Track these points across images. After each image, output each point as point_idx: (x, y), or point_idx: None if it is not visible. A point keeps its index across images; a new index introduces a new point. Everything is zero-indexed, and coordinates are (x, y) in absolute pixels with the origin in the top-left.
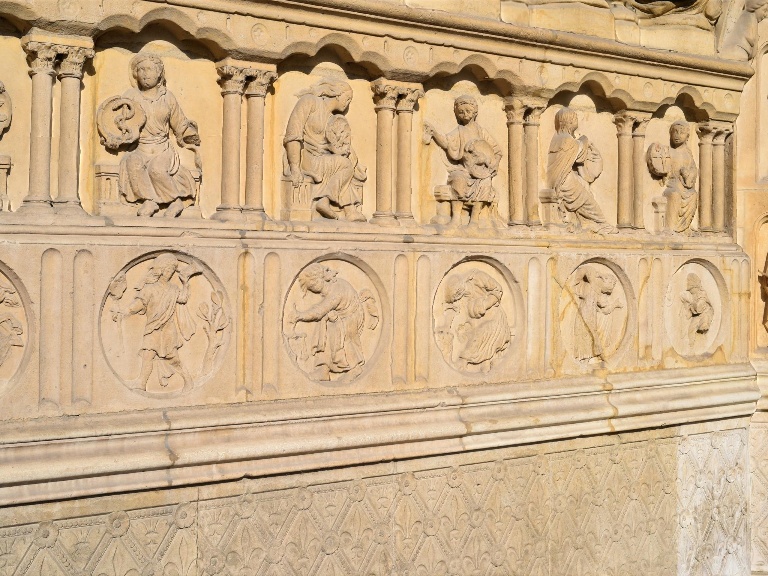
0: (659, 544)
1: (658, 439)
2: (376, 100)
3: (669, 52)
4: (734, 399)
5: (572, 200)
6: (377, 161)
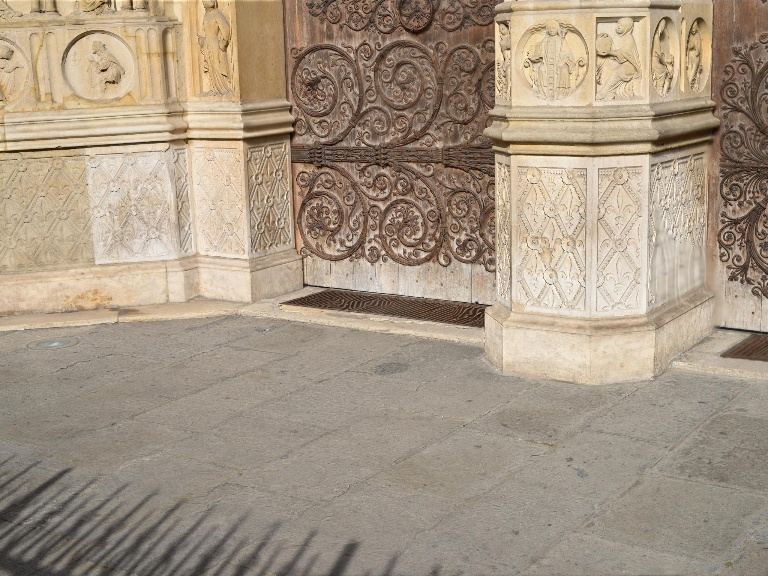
0: (73, 227)
1: (65, 157)
2: None
3: None
4: (134, 130)
5: None
6: None
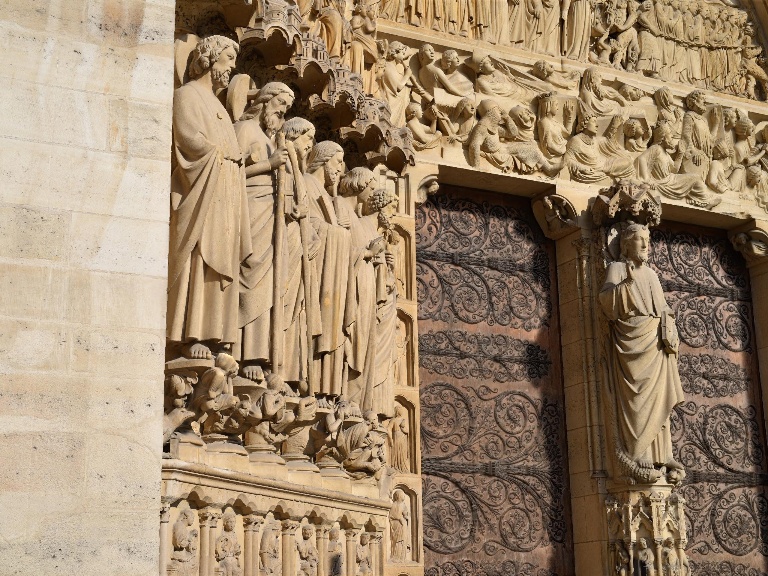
0: None
1: None
2: (283, 530)
3: (366, 498)
4: None
5: (338, 575)
6: (283, 560)
